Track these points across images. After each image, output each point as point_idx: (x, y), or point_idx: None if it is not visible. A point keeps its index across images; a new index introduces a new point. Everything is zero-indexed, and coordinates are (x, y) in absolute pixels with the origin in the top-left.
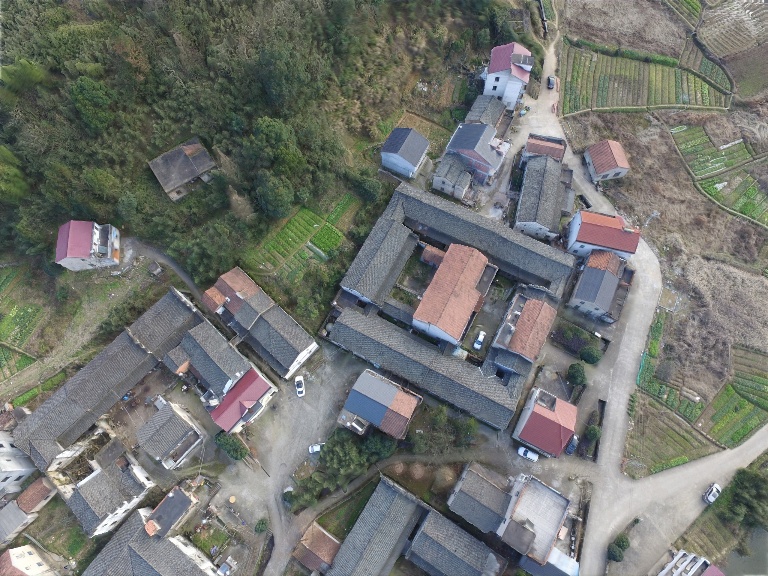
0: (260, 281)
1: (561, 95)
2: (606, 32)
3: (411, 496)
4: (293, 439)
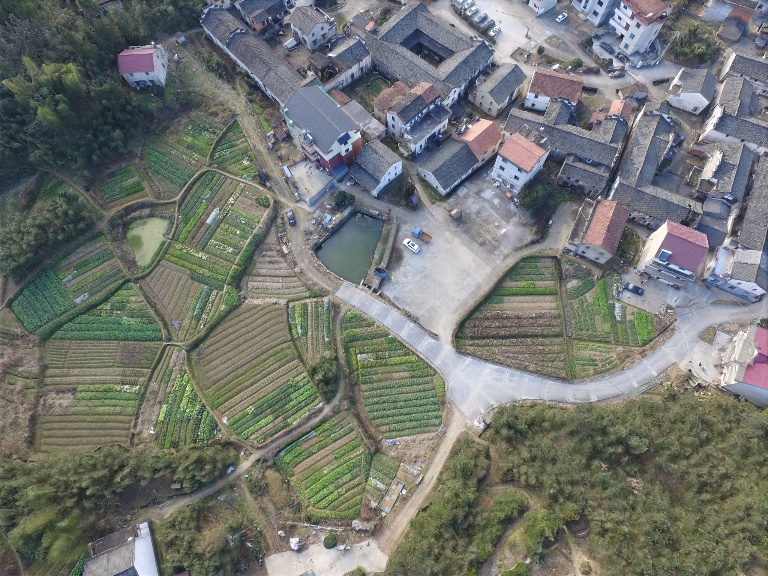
0: None
1: None
2: None
3: None
4: None
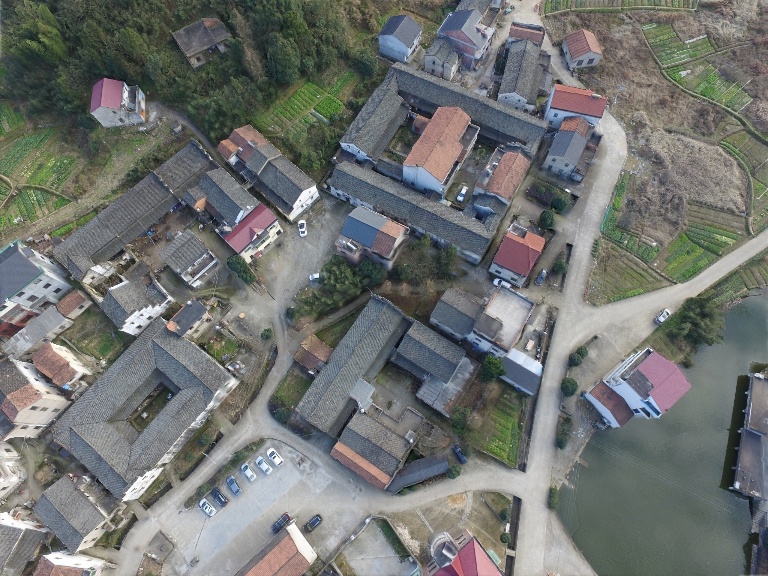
0: None
1: None
2: None
3: (397, 307)
4: (296, 270)
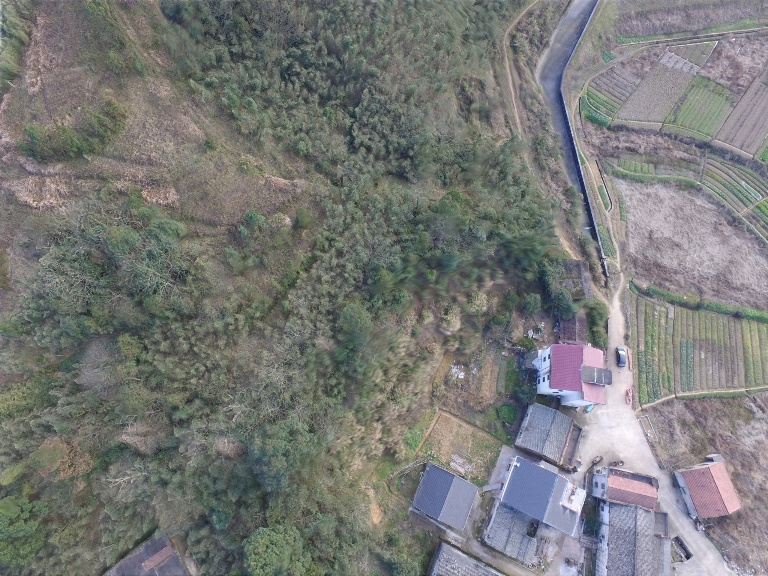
0: None
1: (635, 374)
2: (682, 274)
3: None
4: None
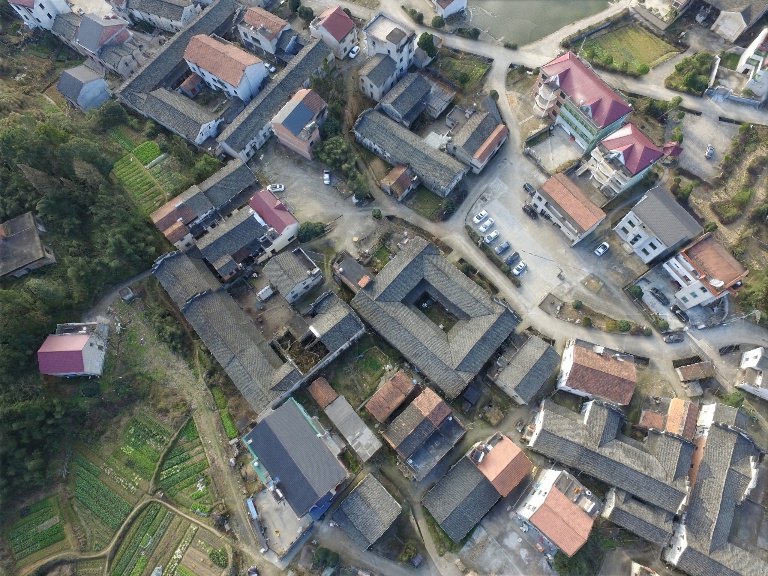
0: None
1: None
2: None
3: (368, 109)
4: (317, 196)
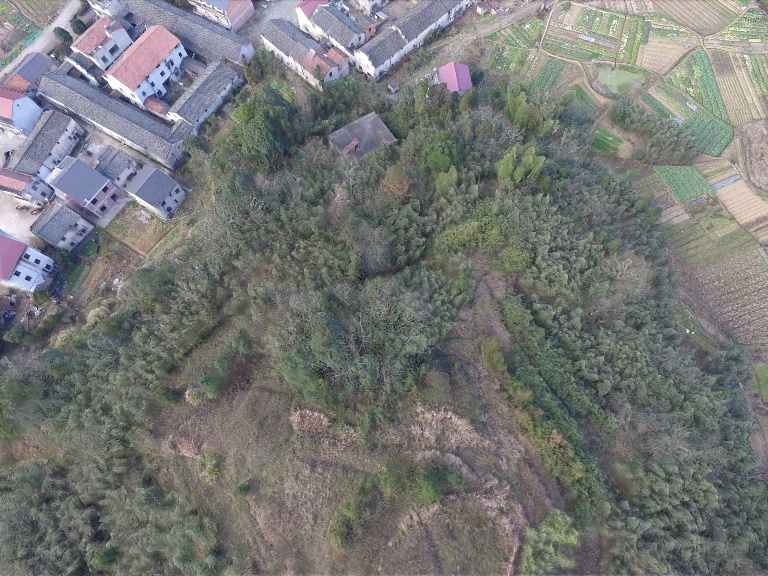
0: (309, 89)
1: None
2: None
3: None
4: (291, 5)
